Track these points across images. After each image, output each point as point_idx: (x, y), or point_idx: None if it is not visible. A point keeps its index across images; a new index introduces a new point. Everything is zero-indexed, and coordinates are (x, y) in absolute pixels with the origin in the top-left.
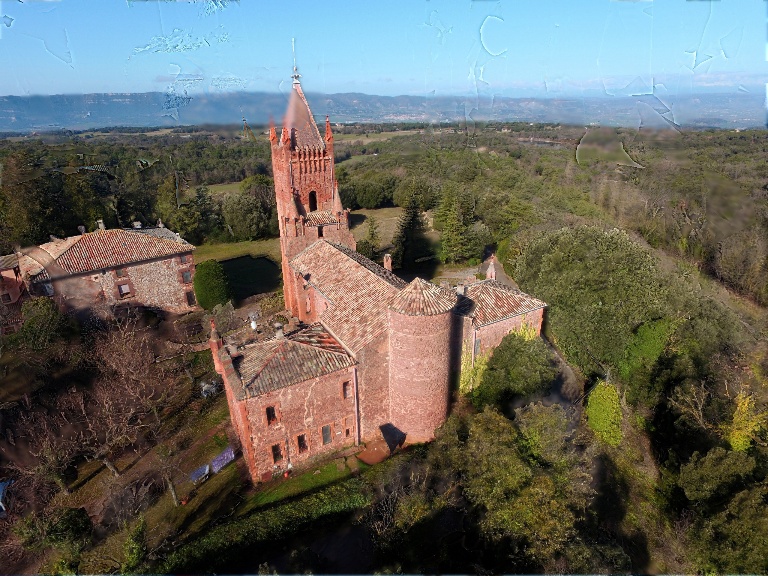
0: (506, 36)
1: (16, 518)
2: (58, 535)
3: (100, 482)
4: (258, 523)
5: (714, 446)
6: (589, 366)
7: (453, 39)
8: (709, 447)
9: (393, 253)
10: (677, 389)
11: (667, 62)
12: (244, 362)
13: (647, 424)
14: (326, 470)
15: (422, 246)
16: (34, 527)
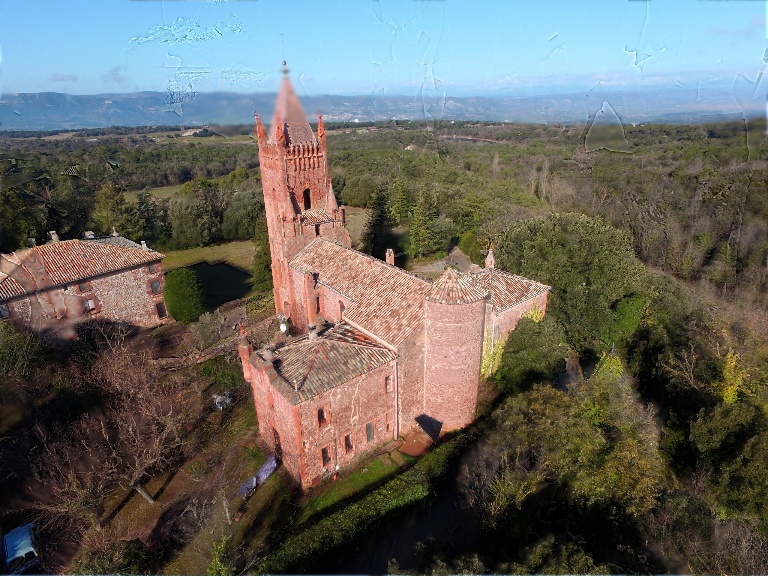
0: (545, 30)
1: (49, 563)
2: (122, 571)
3: (189, 504)
4: (330, 527)
5: (707, 403)
6: (582, 343)
7: (407, 37)
8: (701, 404)
9: (362, 251)
10: (660, 356)
11: None
12: (284, 366)
13: (633, 391)
14: (373, 467)
15: (391, 242)
16: (93, 567)
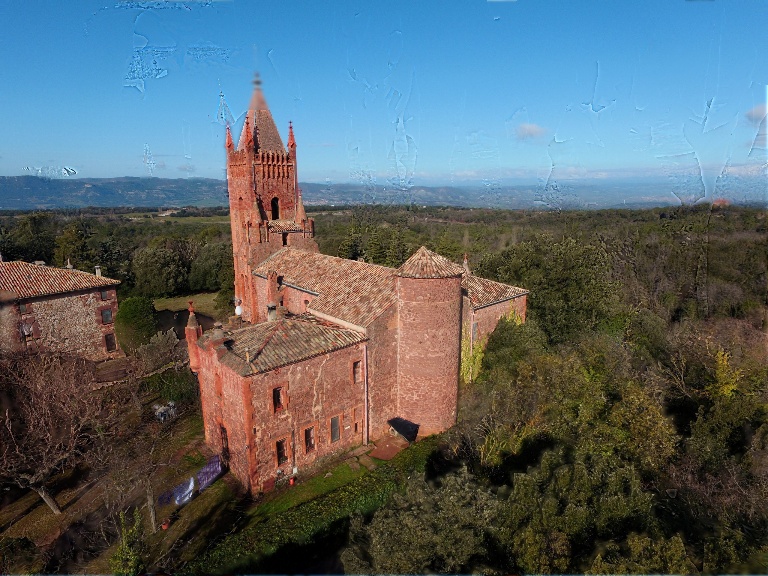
0: None
1: None
2: None
3: (91, 452)
4: (281, 525)
5: None
6: None
7: (379, 94)
8: None
9: None
10: None
11: None
12: (236, 344)
13: None
14: (338, 472)
15: None
16: None
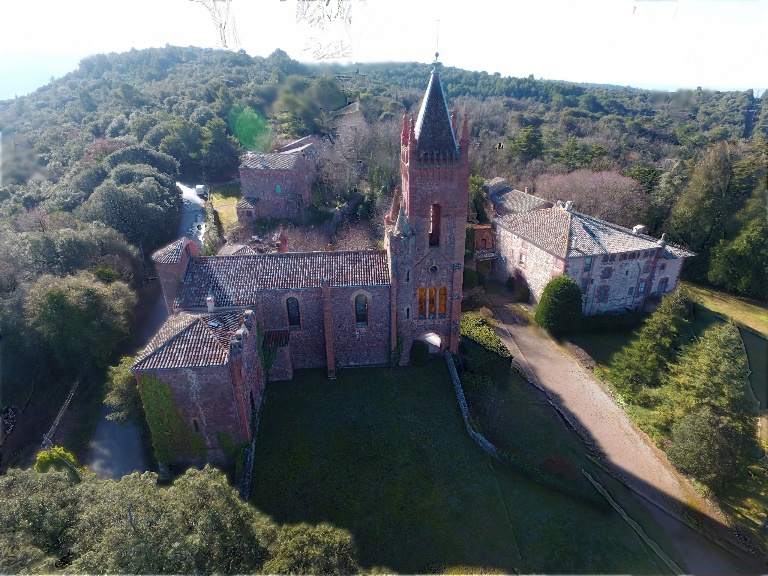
0: None
1: None
2: None
3: None
4: None
5: None
6: None
7: None
8: None
9: None
10: None
11: None
12: None
13: None
14: None
15: None
16: None
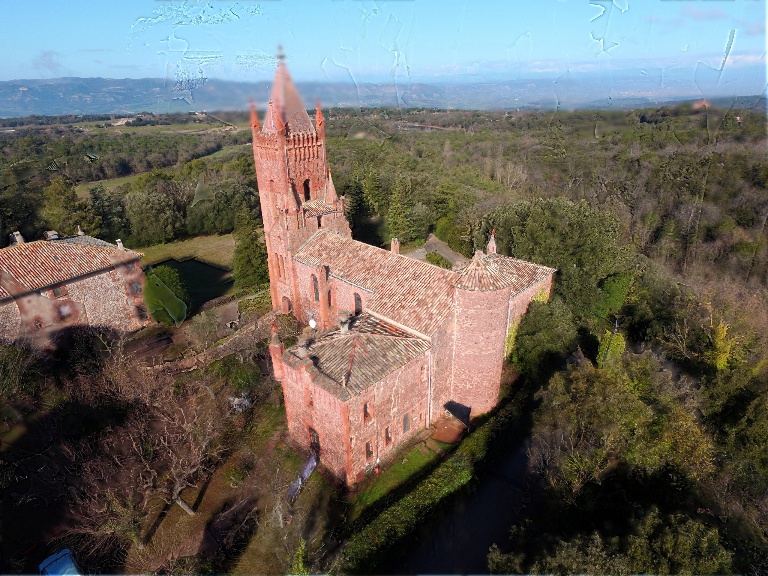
0: (578, 17)
1: None
2: None
3: (276, 511)
4: (391, 520)
5: (701, 370)
6: (578, 322)
7: (377, 22)
8: (694, 372)
9: None
10: (649, 330)
11: (570, 48)
12: (322, 362)
13: None
14: (412, 457)
15: (371, 231)
16: None
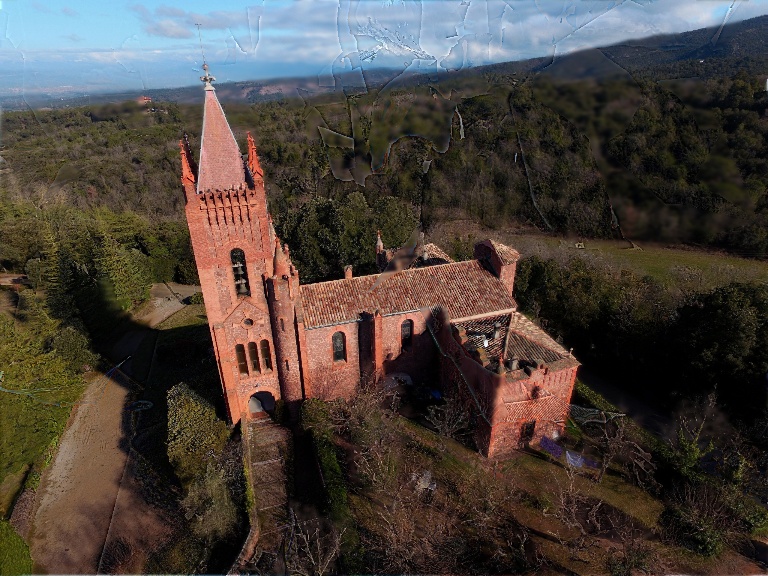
0: None
1: None
2: None
3: None
4: None
5: None
6: None
7: None
8: None
9: None
10: None
11: None
12: (530, 359)
13: None
14: None
15: (102, 303)
16: None
